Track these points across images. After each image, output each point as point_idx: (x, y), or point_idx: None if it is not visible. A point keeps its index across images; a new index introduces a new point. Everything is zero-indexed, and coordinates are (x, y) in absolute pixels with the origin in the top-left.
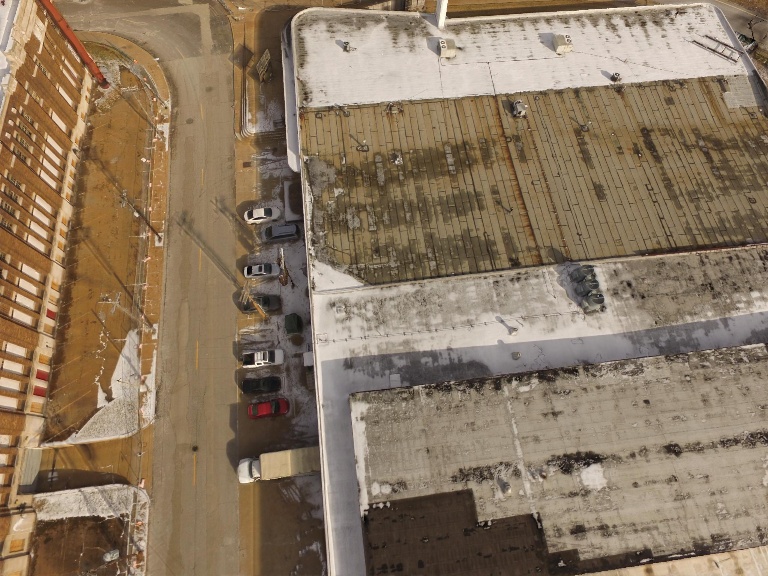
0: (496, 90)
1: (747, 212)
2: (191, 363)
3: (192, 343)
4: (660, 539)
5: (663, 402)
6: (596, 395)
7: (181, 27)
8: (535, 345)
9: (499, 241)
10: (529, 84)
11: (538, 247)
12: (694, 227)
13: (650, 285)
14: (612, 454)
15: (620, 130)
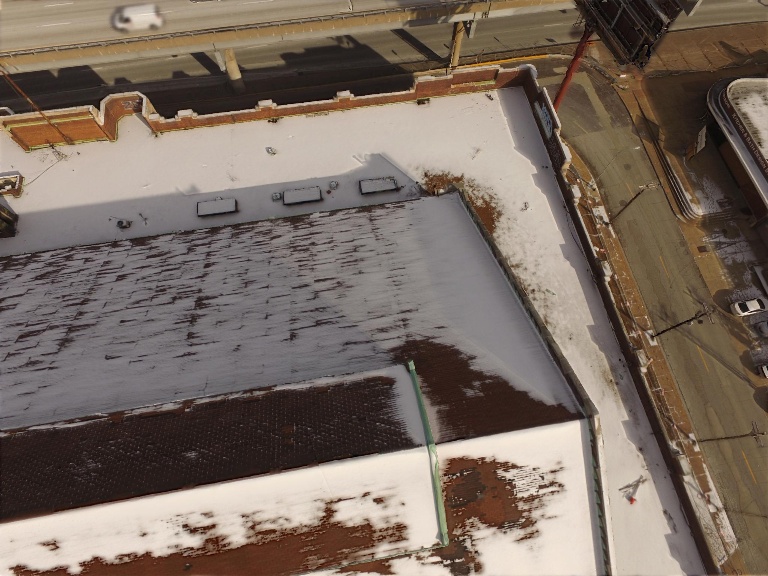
0: None
1: None
2: (747, 477)
3: (738, 454)
4: None
5: None
6: None
7: (569, 99)
8: None
9: None
10: None
11: None
12: None
13: None
14: None
15: None
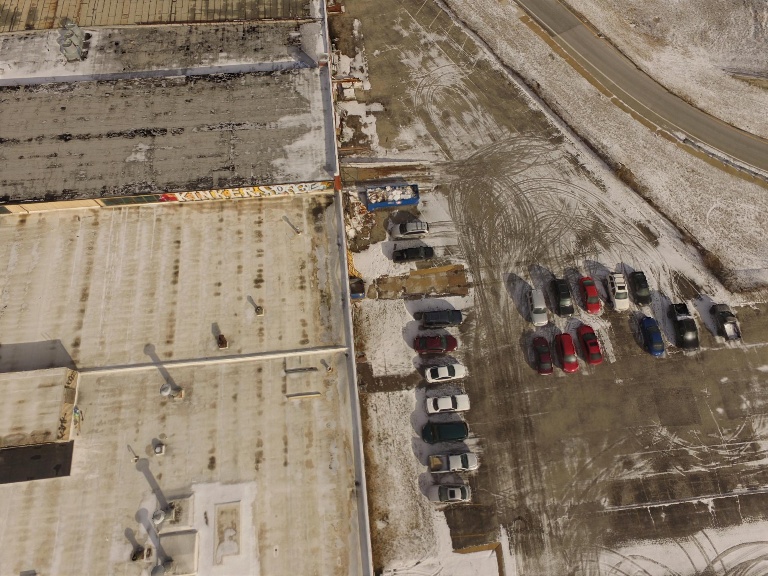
0: None
1: (252, 0)
2: None
3: None
4: (21, 190)
5: (77, 109)
6: (24, 103)
7: None
8: (14, 81)
9: (25, 13)
10: None
11: (55, 17)
12: (198, 8)
13: (135, 45)
14: (13, 138)
15: None
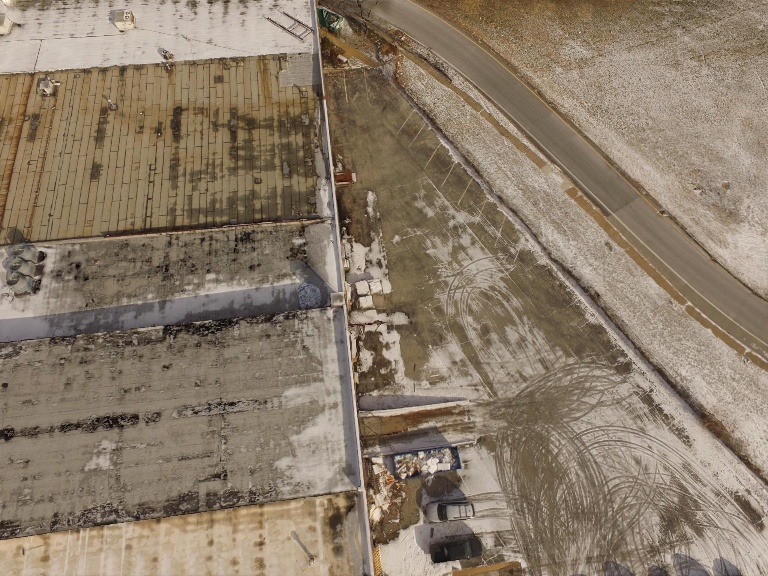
0: (36, 68)
1: (246, 193)
2: None
3: None
4: None
5: (22, 385)
6: None
7: None
8: None
9: None
10: (75, 62)
11: (1, 228)
12: (180, 208)
13: (100, 267)
14: None
15: (152, 109)
